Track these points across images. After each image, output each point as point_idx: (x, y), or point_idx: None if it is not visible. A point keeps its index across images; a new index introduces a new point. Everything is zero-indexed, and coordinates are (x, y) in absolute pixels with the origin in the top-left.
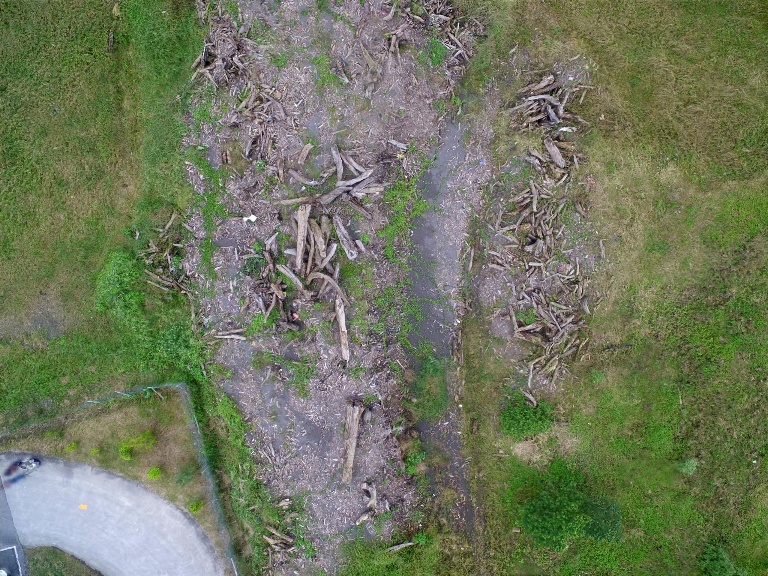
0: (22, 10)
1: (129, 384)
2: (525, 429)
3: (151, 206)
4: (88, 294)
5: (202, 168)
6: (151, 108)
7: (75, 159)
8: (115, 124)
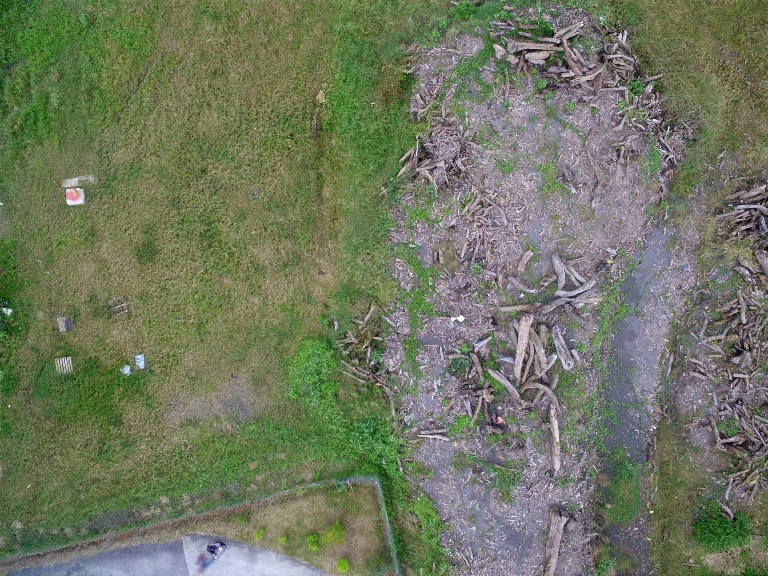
0: (225, 92)
1: (318, 473)
2: (725, 544)
3: (349, 296)
4: (279, 379)
5: (412, 266)
6: (352, 197)
7: (272, 244)
8: (313, 211)
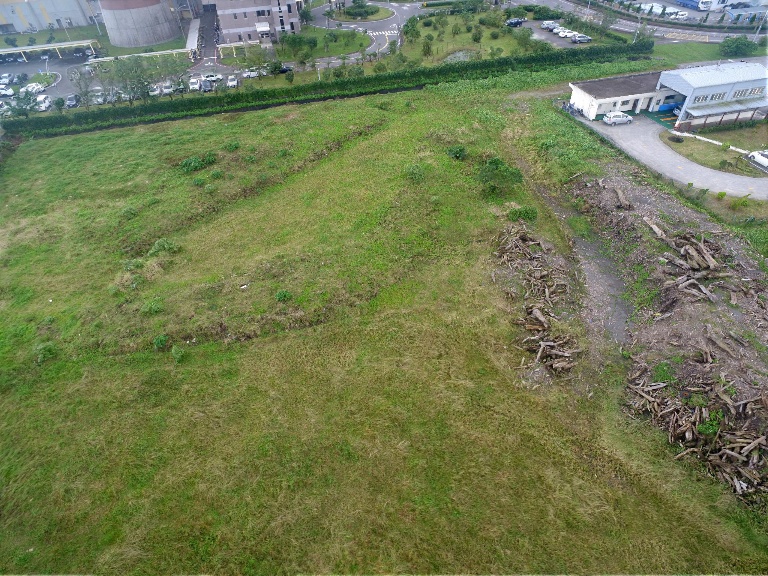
0: None
1: (765, 226)
2: None
3: None
4: None
5: None
6: None
7: None
8: None
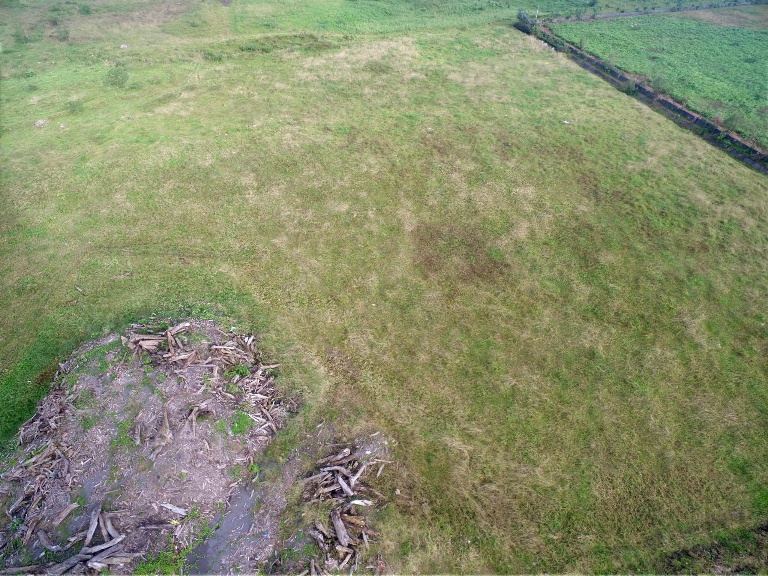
0: None
1: None
2: None
3: None
4: None
5: None
6: None
7: None
8: None
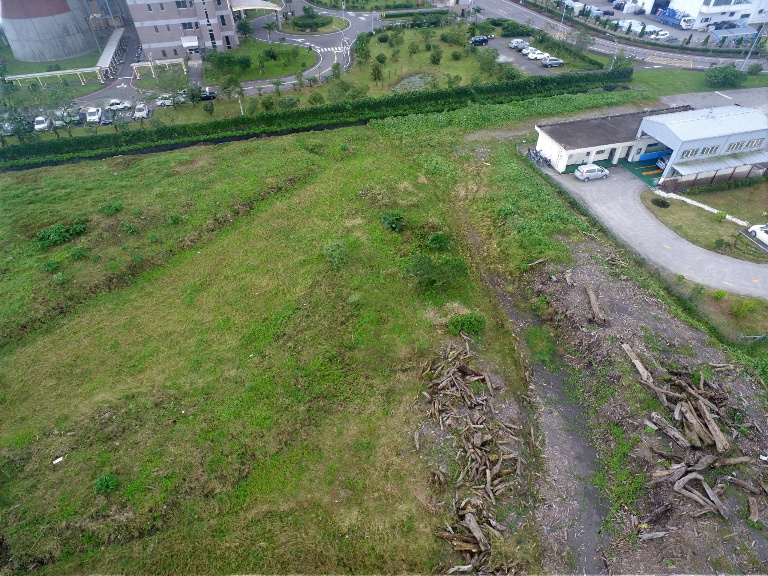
0: None
1: None
2: None
3: None
4: None
5: None
6: None
7: None
8: None
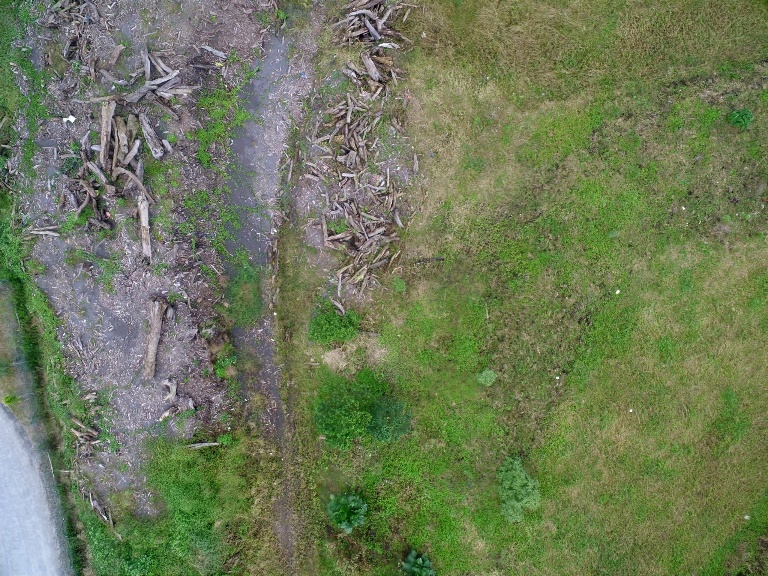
0: None
1: None
2: (328, 335)
3: None
4: None
5: (25, 69)
6: None
7: None
8: None
